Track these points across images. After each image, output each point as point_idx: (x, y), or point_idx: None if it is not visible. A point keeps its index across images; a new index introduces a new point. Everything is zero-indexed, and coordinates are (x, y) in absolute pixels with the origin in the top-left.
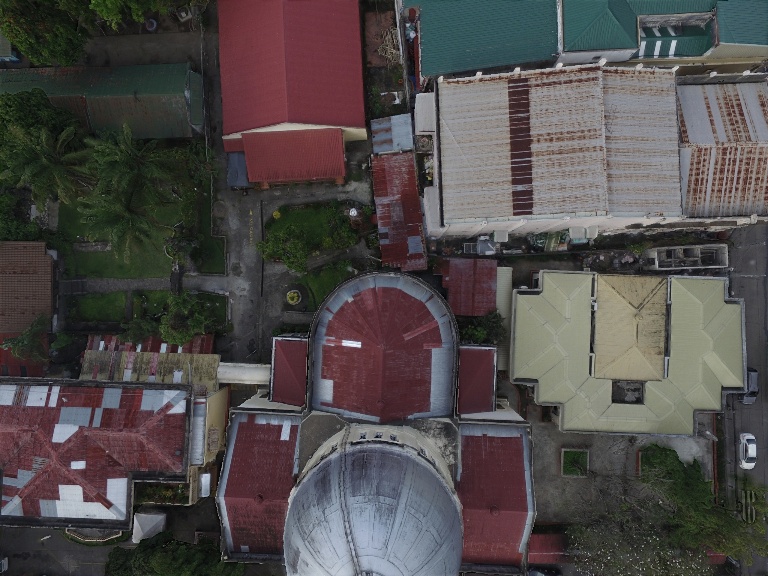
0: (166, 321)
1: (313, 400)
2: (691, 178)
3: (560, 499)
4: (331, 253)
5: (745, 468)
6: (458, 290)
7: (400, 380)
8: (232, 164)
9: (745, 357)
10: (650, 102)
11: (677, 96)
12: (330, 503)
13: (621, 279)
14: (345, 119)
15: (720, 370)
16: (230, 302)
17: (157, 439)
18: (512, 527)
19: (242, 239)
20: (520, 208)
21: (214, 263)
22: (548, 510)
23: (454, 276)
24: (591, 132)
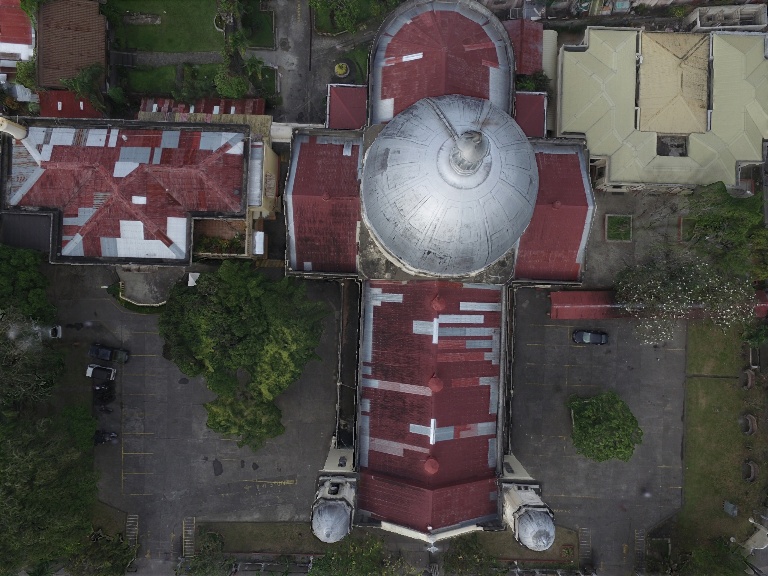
0: (222, 70)
1: (373, 122)
2: None
3: (604, 265)
4: None
5: None
6: None
7: (461, 87)
8: None
9: None
10: None
11: None
12: (417, 108)
13: (665, 35)
14: None
15: (761, 120)
16: (279, 76)
17: (216, 177)
18: (571, 228)
19: (290, 15)
20: None
21: (263, 36)
22: (592, 275)
23: None
24: None
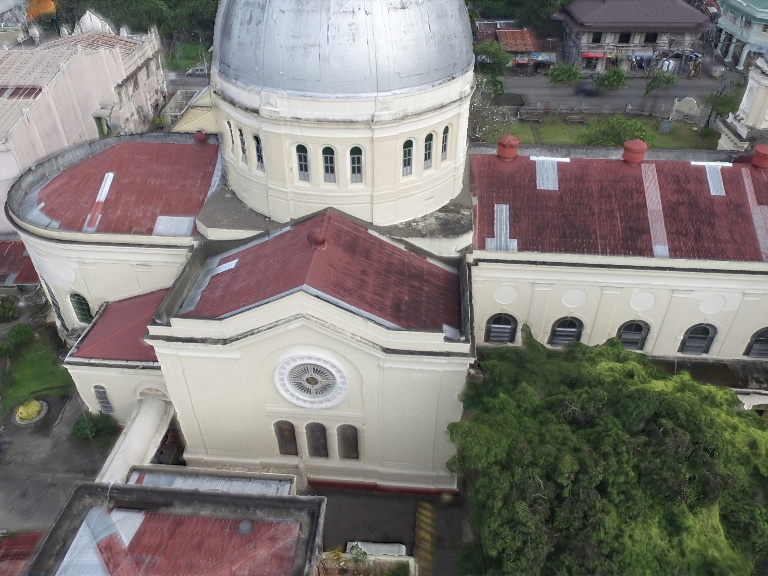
0: None
1: None
2: None
3: None
4: None
5: None
6: None
7: None
8: None
9: None
10: None
11: None
12: None
13: None
14: None
15: None
16: None
17: (188, 570)
18: None
19: None
20: (30, 95)
21: None
22: None
23: None
24: None
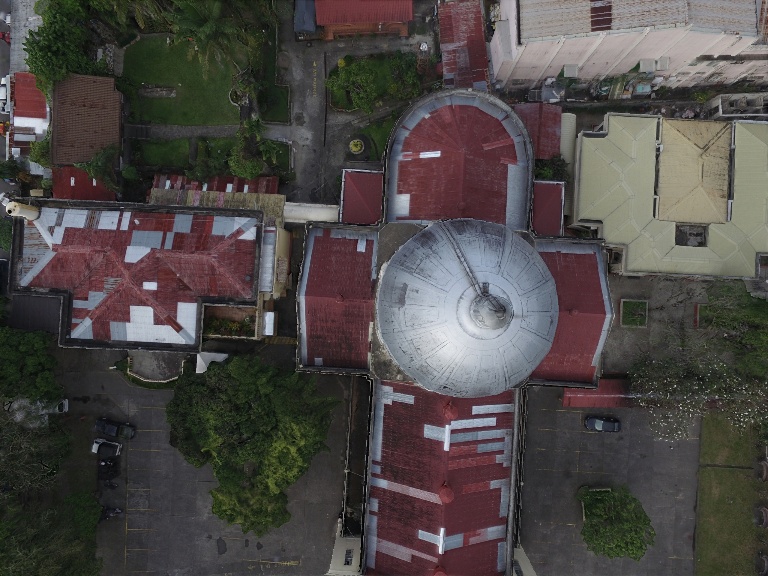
0: (236, 152)
1: (388, 216)
2: (764, 6)
3: (618, 350)
4: (394, 105)
5: None
6: None
7: (479, 188)
8: (299, 9)
9: None
10: None
11: None
12: (436, 241)
13: (686, 123)
14: None
15: None
16: (293, 151)
17: (228, 263)
18: (588, 334)
19: (305, 90)
20: (598, 24)
21: (278, 111)
22: (606, 360)
23: None
24: None
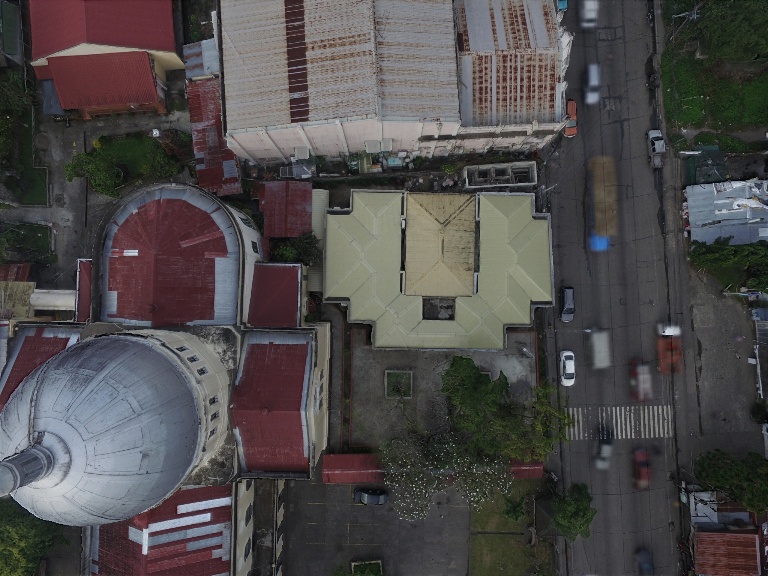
0: None
1: (101, 313)
2: (475, 87)
3: (385, 421)
4: None
5: (565, 385)
6: (272, 213)
7: (176, 286)
8: (47, 93)
9: (552, 271)
10: (425, 9)
11: (463, 8)
12: (32, 377)
13: (430, 197)
14: (152, 43)
15: (527, 284)
16: (54, 233)
17: None
18: (290, 429)
19: None
20: (297, 115)
21: (36, 194)
22: (374, 432)
23: (269, 199)
24: (361, 37)
